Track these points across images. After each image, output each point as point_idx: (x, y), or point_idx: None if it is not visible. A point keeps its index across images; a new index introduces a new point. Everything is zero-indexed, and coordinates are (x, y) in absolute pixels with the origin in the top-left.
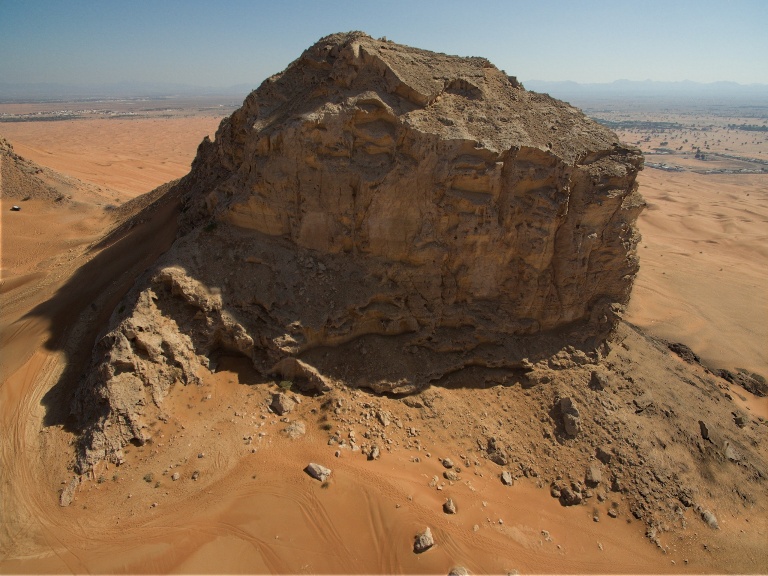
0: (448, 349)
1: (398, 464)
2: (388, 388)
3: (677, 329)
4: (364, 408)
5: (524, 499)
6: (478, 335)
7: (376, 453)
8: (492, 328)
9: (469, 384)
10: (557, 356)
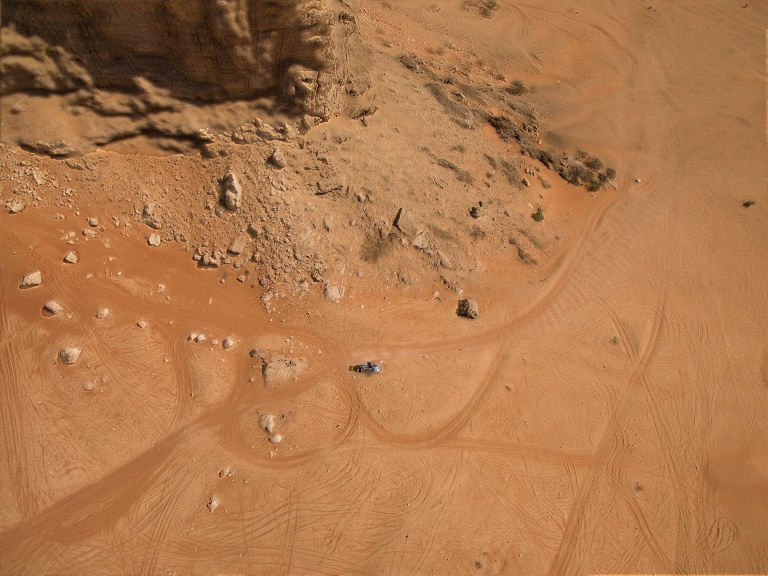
0: (119, 112)
1: (38, 219)
2: (48, 148)
3: (575, 94)
4: (19, 166)
5: (161, 259)
6: (148, 99)
7: (18, 208)
8: (165, 92)
9: (146, 150)
10: (241, 129)
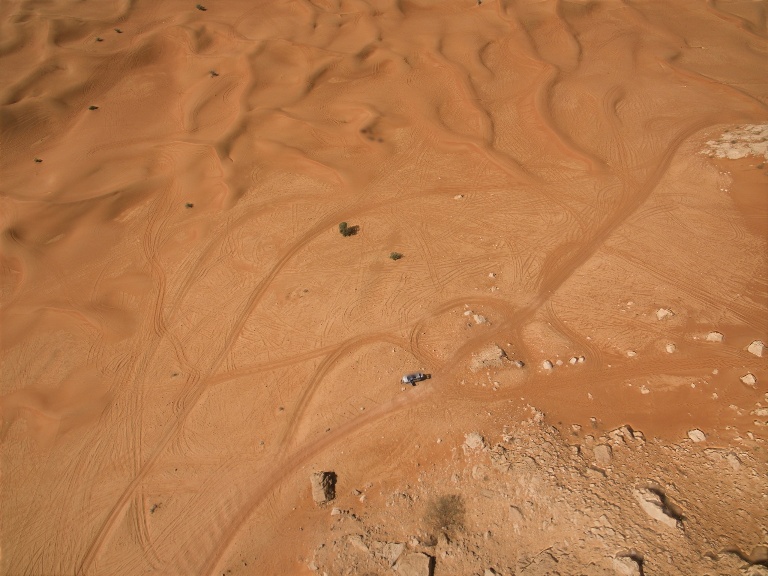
0: None
1: None
2: None
3: None
4: None
5: (673, 419)
6: None
7: None
8: None
9: None
10: None
